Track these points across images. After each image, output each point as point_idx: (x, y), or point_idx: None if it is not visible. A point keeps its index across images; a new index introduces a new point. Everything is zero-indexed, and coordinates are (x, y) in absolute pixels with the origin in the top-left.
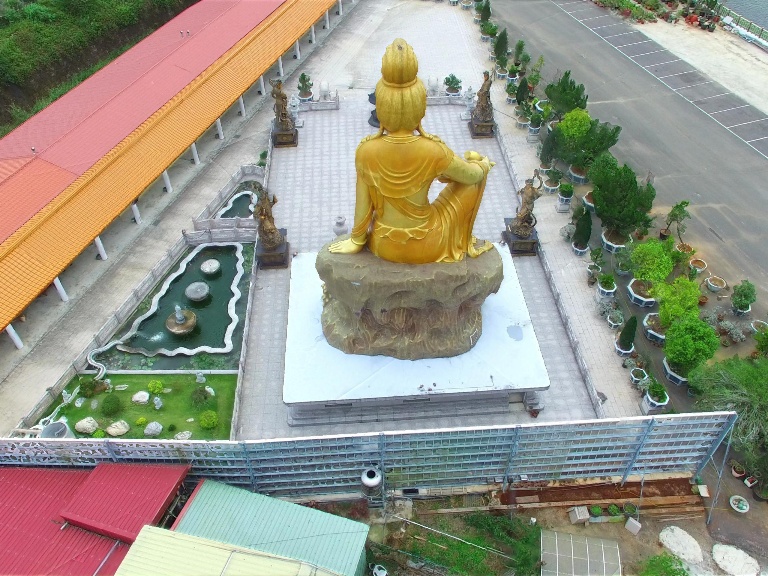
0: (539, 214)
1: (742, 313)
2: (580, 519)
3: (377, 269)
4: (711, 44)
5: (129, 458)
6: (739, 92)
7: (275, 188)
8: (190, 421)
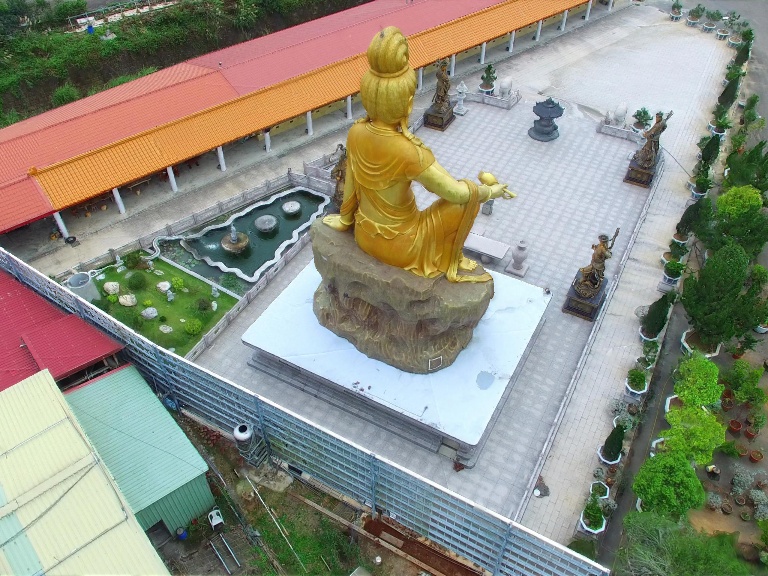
0: (634, 283)
1: None
2: None
3: (347, 252)
4: None
5: (93, 320)
6: None
7: None
8: (182, 321)
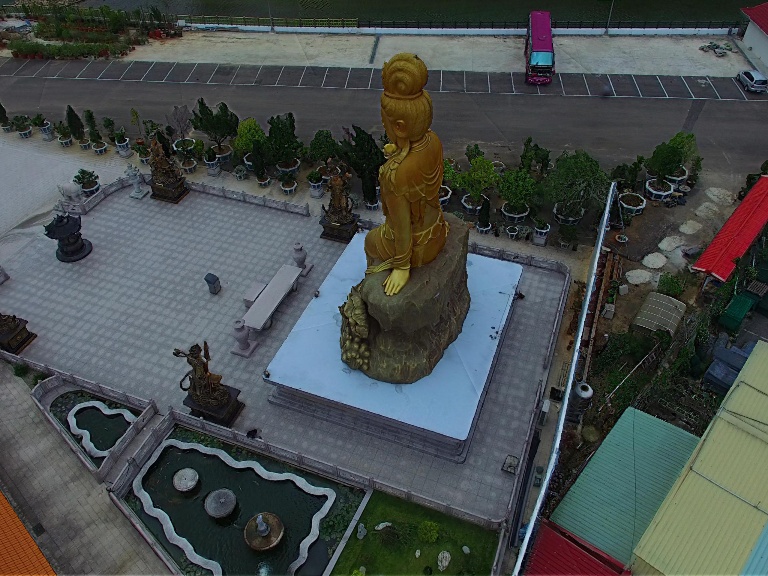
0: (313, 209)
1: None
2: None
3: (435, 273)
4: (196, 44)
5: None
6: (266, 63)
7: (96, 379)
8: (420, 554)
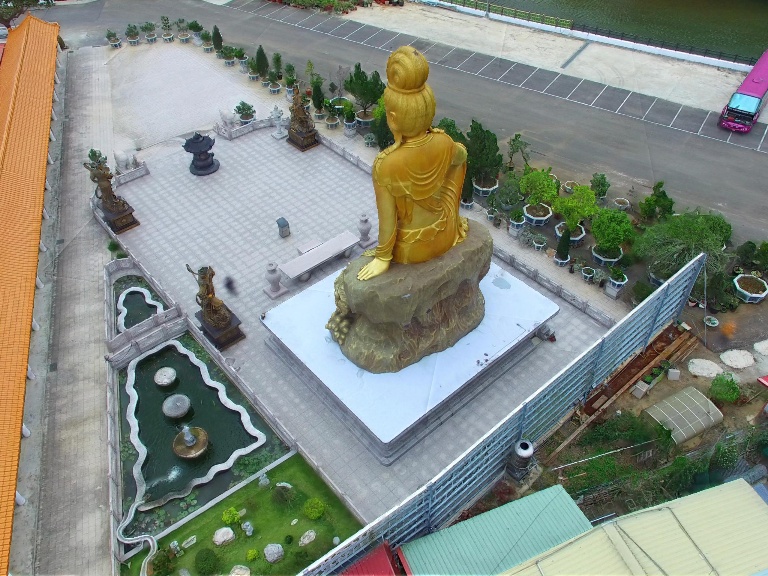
0: None
1: (603, 199)
2: (645, 391)
3: (416, 274)
4: None
5: None
6: (461, 46)
7: (157, 272)
8: (295, 523)
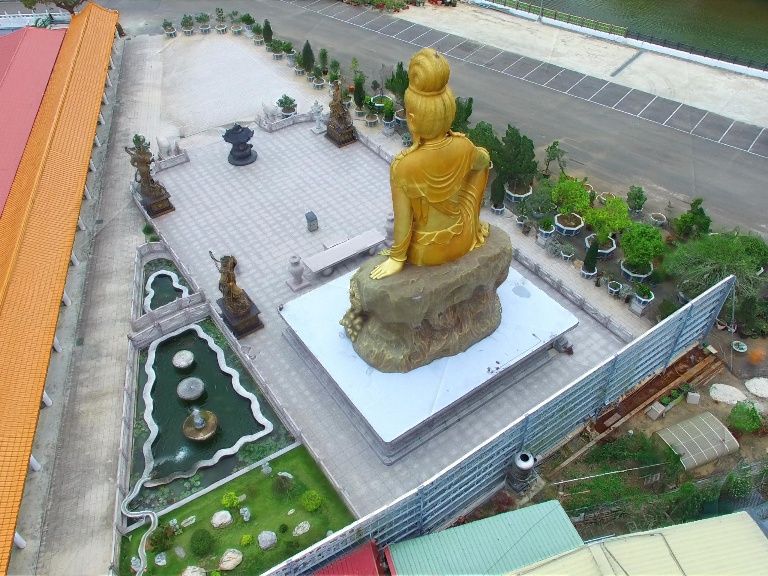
0: None
1: (639, 212)
2: (660, 413)
3: (429, 277)
4: (462, 16)
5: (307, 570)
6: (509, 49)
7: (186, 258)
8: (292, 513)
